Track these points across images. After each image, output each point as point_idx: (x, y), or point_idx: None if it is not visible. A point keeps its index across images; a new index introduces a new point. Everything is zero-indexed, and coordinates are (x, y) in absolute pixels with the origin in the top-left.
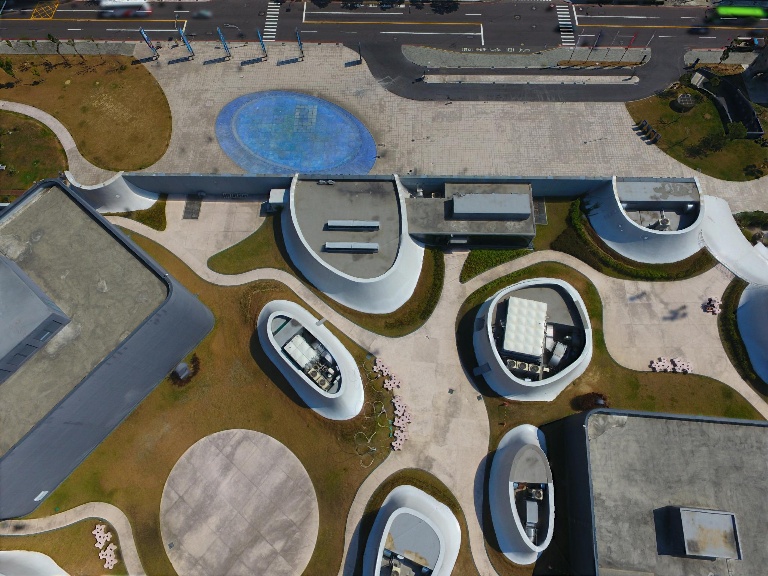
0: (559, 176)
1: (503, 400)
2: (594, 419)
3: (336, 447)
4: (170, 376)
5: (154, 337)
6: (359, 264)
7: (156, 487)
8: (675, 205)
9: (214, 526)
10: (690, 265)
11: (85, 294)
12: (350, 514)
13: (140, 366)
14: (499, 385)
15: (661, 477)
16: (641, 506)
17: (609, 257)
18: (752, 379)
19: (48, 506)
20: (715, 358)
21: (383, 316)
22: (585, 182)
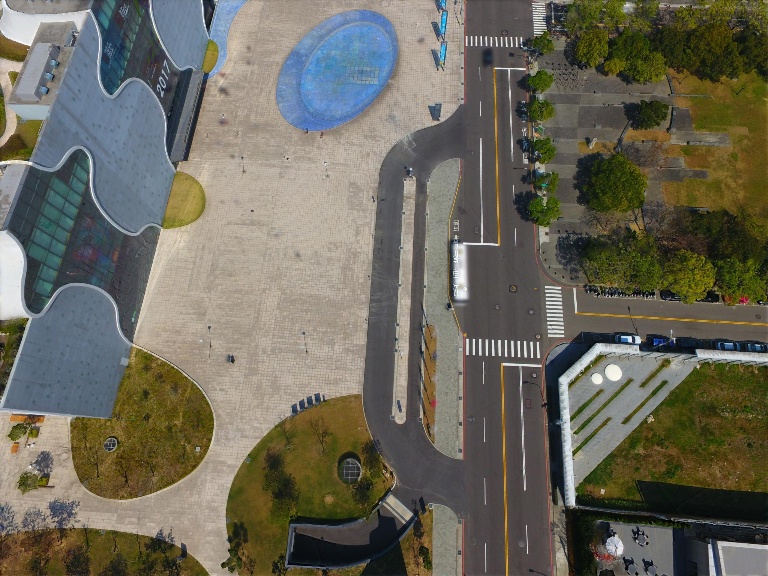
0: (47, 121)
1: None
2: None
3: None
4: None
5: None
6: None
7: None
8: None
9: None
10: None
11: None
12: None
13: None
14: None
15: None
16: None
17: None
18: None
19: None
20: None
21: None
22: None
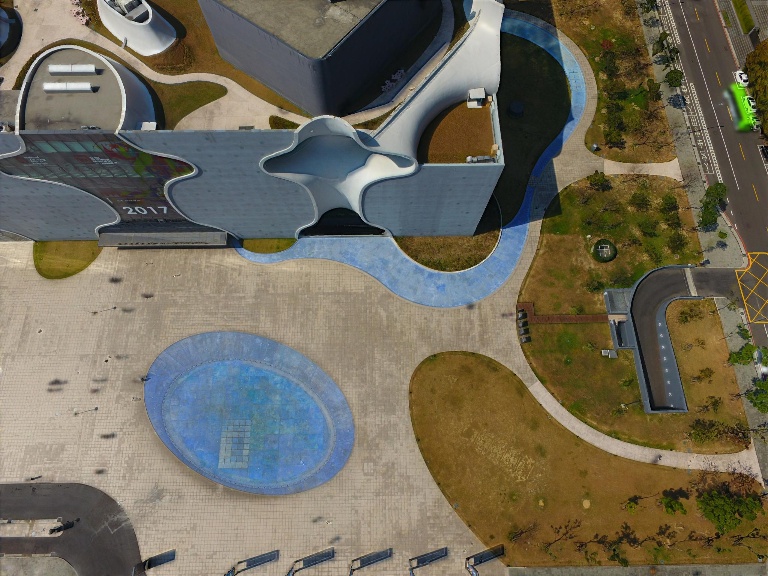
0: None
1: None
2: None
3: None
4: None
5: None
6: (72, 61)
7: None
8: None
9: None
10: None
11: None
12: None
13: None
14: None
15: None
16: None
17: None
18: None
19: None
20: None
21: None
22: None
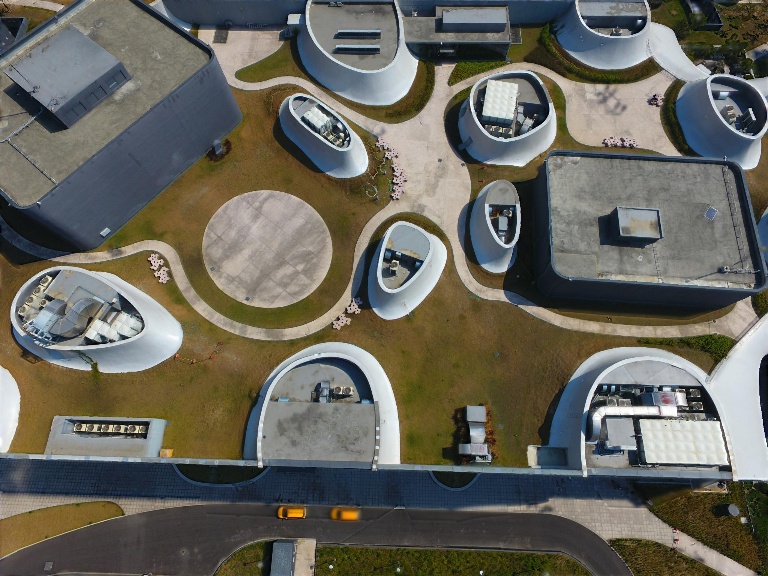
0: None
1: (482, 165)
2: (554, 159)
3: (346, 199)
4: (207, 155)
5: (198, 99)
6: (364, 62)
7: (198, 230)
8: (627, 22)
9: (247, 256)
10: (639, 71)
11: (142, 61)
12: (358, 244)
13: (186, 127)
14: (479, 153)
15: (605, 196)
16: (588, 215)
17: (572, 65)
18: (686, 151)
19: (110, 244)
20: (657, 137)
21: (384, 107)
22: (553, 4)
